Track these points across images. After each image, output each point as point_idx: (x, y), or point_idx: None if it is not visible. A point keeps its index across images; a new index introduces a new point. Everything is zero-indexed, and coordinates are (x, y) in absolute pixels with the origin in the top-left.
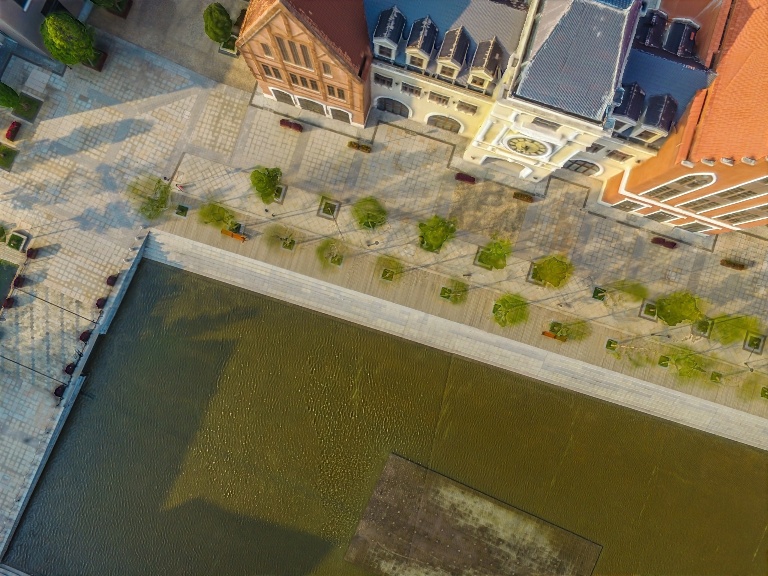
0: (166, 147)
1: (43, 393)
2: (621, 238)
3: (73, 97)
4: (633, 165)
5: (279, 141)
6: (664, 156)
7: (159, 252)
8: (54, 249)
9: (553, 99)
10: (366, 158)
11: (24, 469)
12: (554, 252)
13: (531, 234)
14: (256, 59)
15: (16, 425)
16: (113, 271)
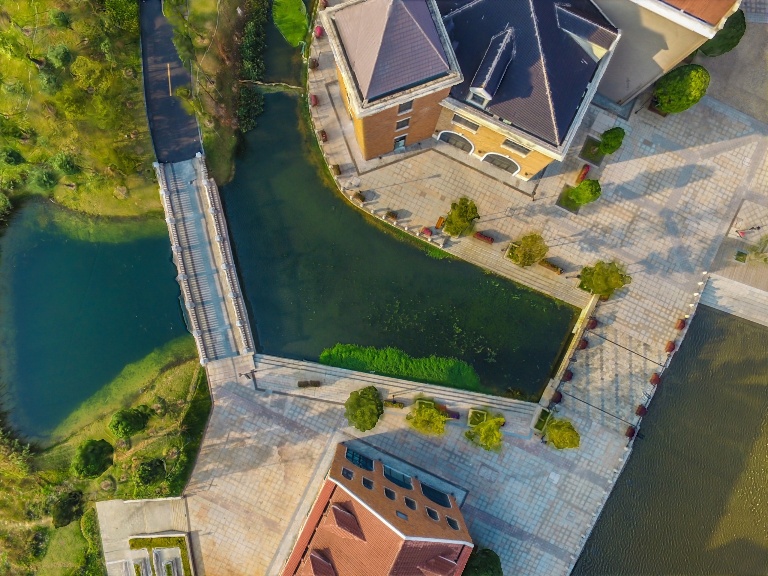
0: (726, 193)
1: (612, 433)
2: None
3: (638, 141)
4: None
5: None
6: None
7: (711, 296)
8: (622, 292)
9: None
10: None
11: (590, 507)
12: None
13: None
14: None
15: (584, 464)
16: (679, 315)
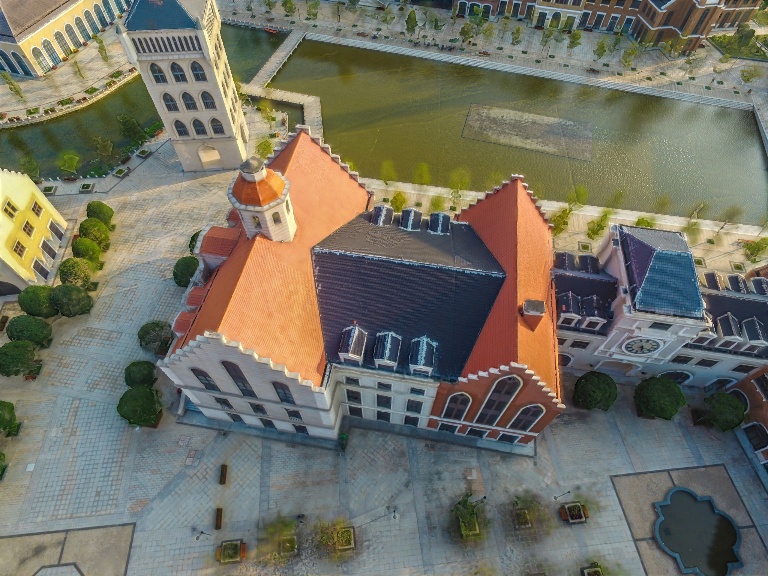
0: None
1: None
2: None
3: None
4: None
5: None
6: None
7: None
8: None
9: None
10: None
11: None
12: None
13: None
14: None
15: None
16: None
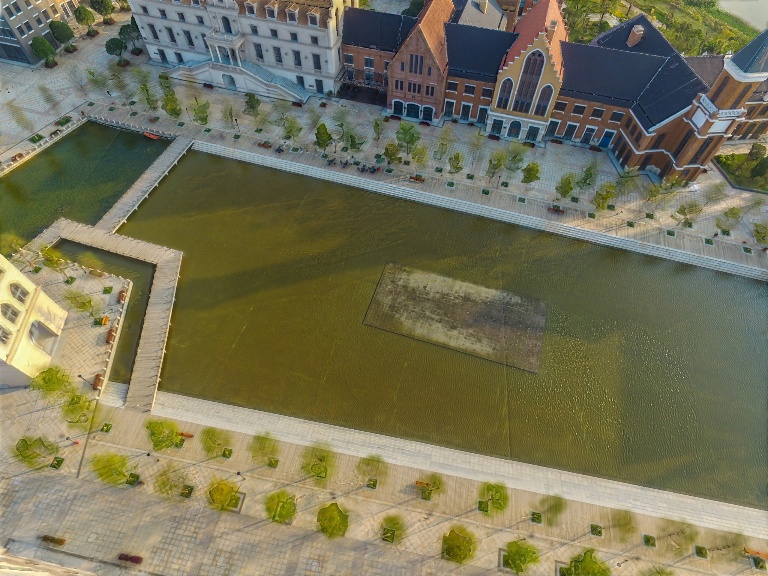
0: None
1: None
2: None
3: None
4: None
5: None
6: None
7: None
8: None
9: None
10: None
11: None
12: None
13: None
14: None
15: None
16: None
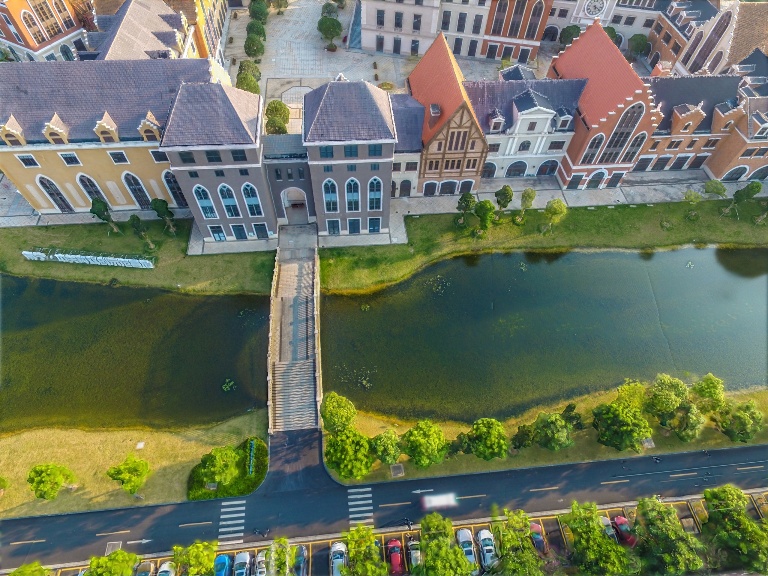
0: None
1: None
2: None
3: None
4: None
5: None
6: None
7: None
8: (727, 0)
9: None
10: None
11: None
12: None
13: None
14: None
15: None
16: None
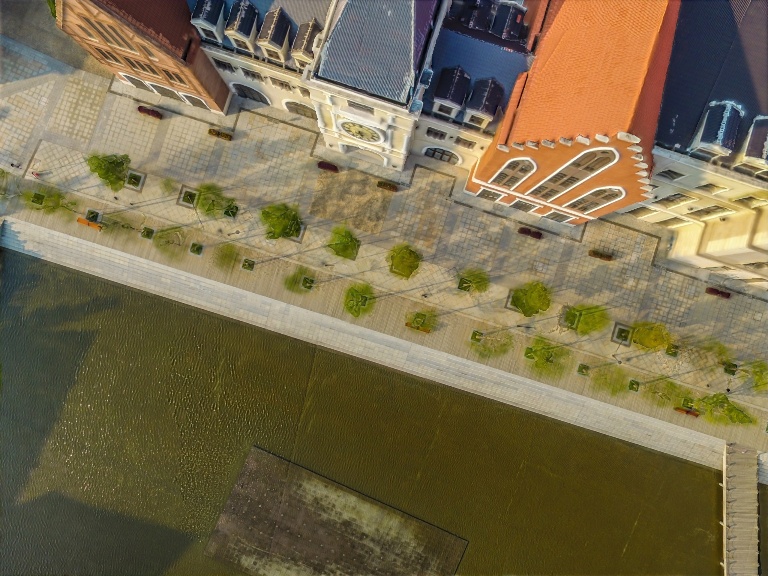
0: (22, 134)
1: None
2: (487, 228)
3: None
4: (482, 152)
5: (138, 128)
6: (494, 141)
7: (16, 241)
8: None
9: (356, 80)
10: (227, 146)
11: None
12: (419, 242)
13: (395, 224)
14: (86, 42)
15: None
16: None
